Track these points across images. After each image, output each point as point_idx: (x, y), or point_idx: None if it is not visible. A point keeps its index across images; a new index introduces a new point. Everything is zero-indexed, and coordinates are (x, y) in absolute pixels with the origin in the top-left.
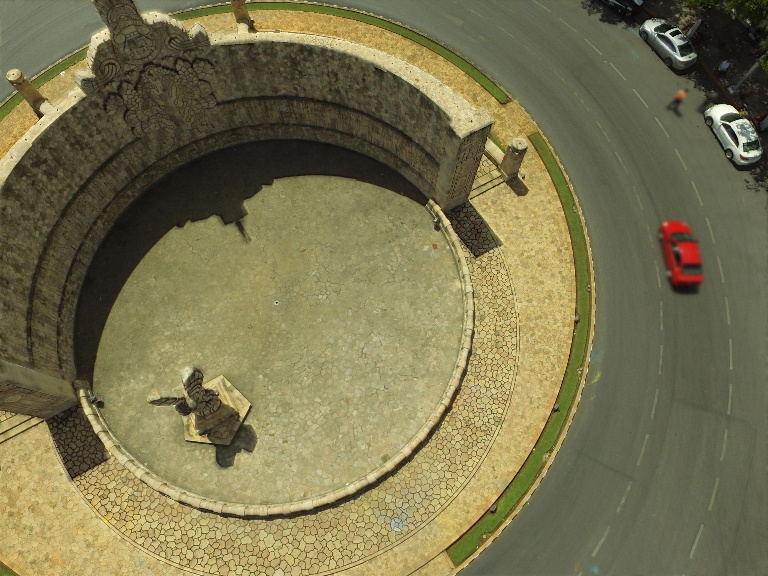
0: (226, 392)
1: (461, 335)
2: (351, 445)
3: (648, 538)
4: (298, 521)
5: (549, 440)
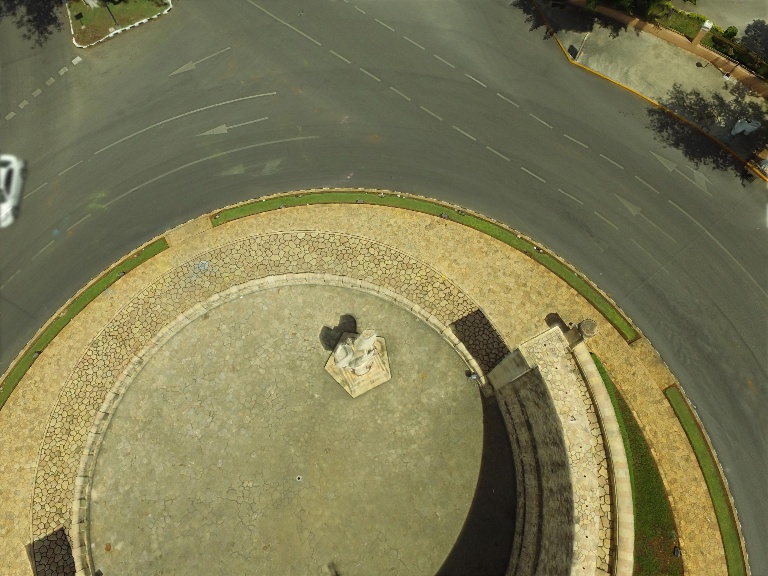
0: (346, 378)
1: (107, 432)
2: (235, 329)
3: (4, 251)
4: (284, 271)
5: (55, 327)
